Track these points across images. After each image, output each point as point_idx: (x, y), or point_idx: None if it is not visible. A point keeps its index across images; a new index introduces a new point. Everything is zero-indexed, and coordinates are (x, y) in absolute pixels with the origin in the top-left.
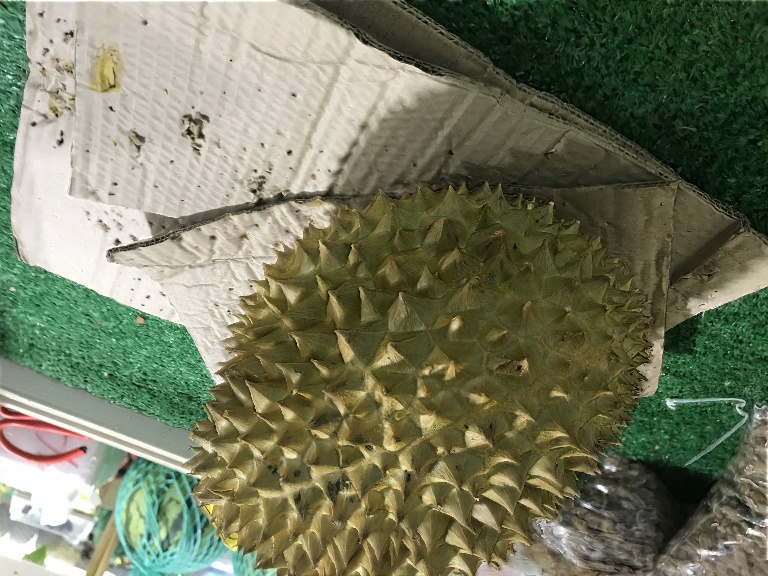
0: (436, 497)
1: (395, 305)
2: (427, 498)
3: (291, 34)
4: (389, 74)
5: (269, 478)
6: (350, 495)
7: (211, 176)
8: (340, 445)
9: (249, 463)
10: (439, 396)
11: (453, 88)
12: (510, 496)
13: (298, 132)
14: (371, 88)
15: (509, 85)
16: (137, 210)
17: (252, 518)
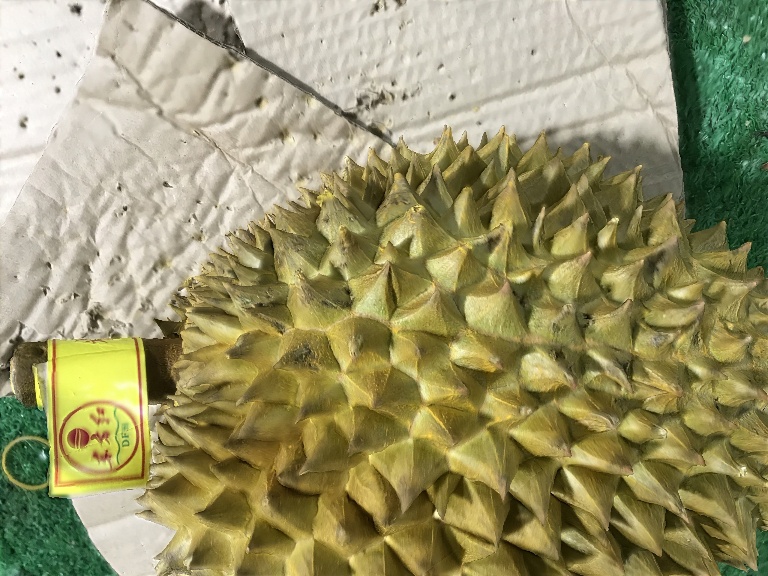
0: (733, 458)
1: (711, 230)
2: (712, 457)
3: (615, 1)
4: (638, 104)
5: (518, 304)
6: (622, 398)
7: (349, 44)
8: (645, 319)
9: (480, 270)
10: (766, 335)
11: (672, 156)
12: (751, 522)
13: (488, 86)
14: (606, 103)
15: (683, 196)
16: (170, 3)
17: (431, 356)
